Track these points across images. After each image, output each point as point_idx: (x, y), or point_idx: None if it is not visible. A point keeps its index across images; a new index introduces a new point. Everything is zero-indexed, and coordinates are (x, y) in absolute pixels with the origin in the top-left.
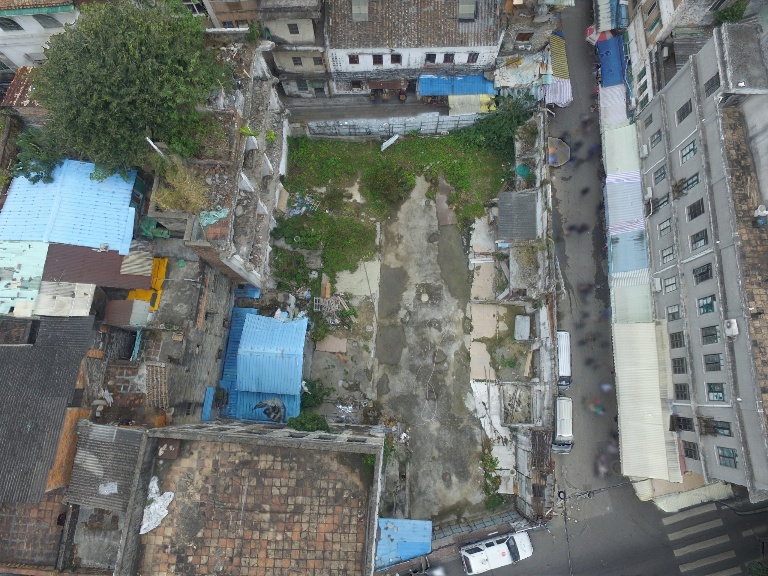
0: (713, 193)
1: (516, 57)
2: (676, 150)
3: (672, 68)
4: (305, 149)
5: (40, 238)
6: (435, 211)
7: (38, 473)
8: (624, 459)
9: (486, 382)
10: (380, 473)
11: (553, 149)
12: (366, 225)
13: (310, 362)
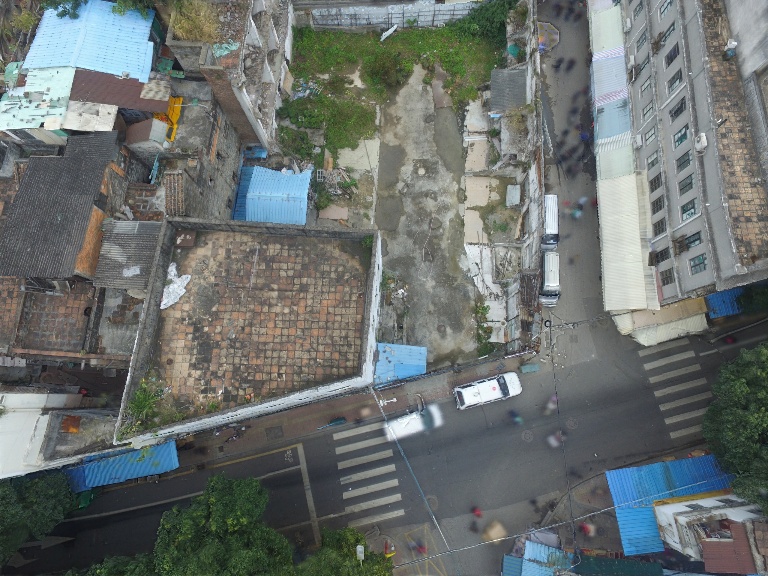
0: (687, 32)
1: None
2: (655, 10)
3: None
4: (309, 39)
5: (67, 63)
6: (432, 95)
7: (68, 254)
8: (606, 296)
9: (479, 245)
10: None
11: (543, 31)
12: (366, 108)
13: None
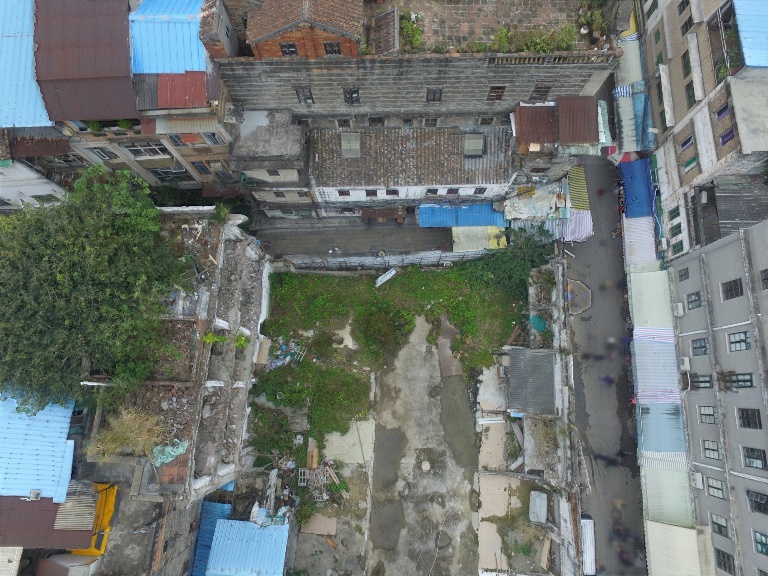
0: None
1: (529, 186)
2: (721, 330)
3: (711, 214)
4: (290, 285)
5: None
6: (437, 359)
7: None
8: None
9: (497, 572)
10: None
11: (572, 296)
12: (359, 376)
13: (294, 547)
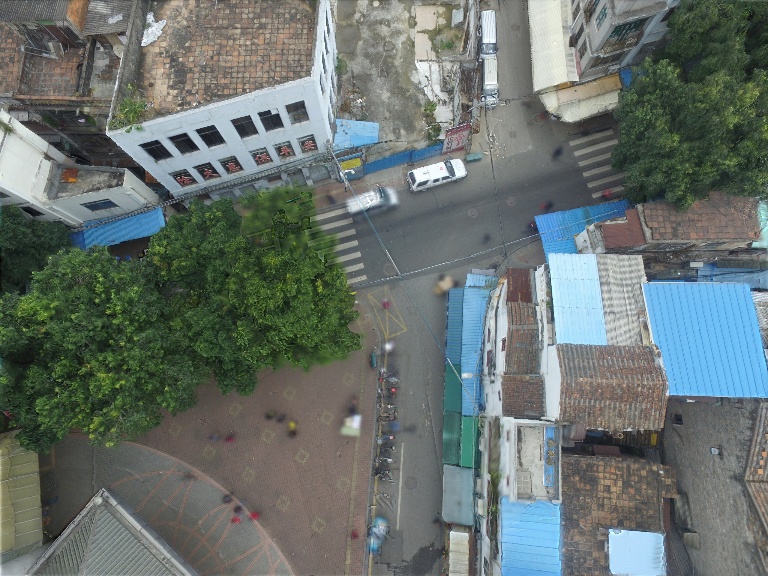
0: None
1: None
2: None
3: None
4: None
5: None
6: None
7: (61, 3)
8: (535, 80)
9: (428, 61)
10: (325, 4)
11: None
12: None
13: None
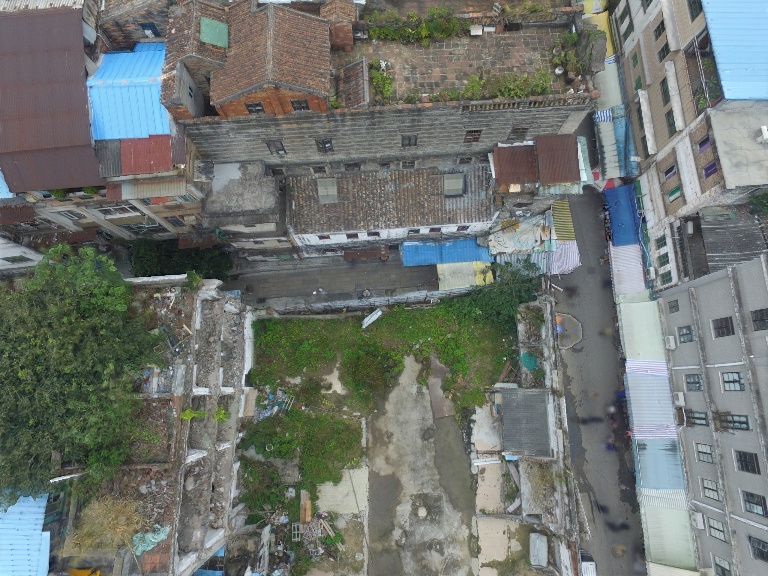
0: None
1: (513, 220)
2: (715, 368)
3: (698, 244)
4: (274, 332)
5: None
6: (429, 400)
7: None
8: None
9: None
10: None
11: (562, 331)
12: (349, 422)
13: None
